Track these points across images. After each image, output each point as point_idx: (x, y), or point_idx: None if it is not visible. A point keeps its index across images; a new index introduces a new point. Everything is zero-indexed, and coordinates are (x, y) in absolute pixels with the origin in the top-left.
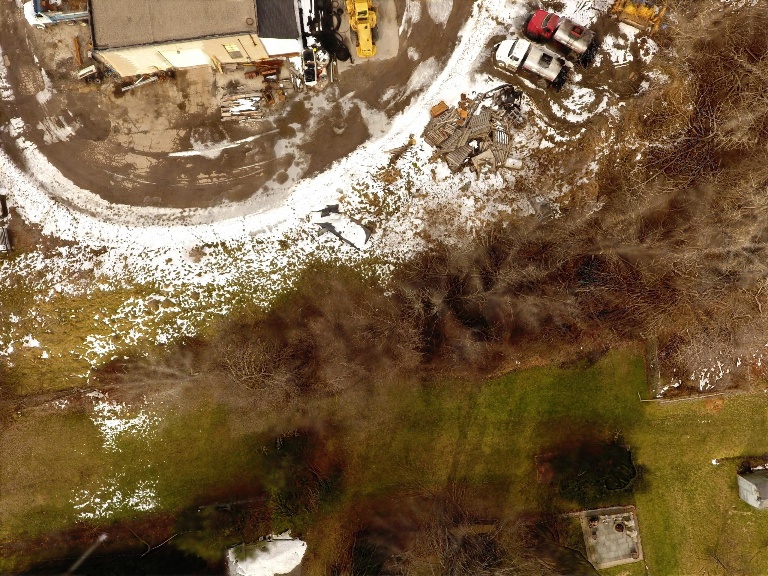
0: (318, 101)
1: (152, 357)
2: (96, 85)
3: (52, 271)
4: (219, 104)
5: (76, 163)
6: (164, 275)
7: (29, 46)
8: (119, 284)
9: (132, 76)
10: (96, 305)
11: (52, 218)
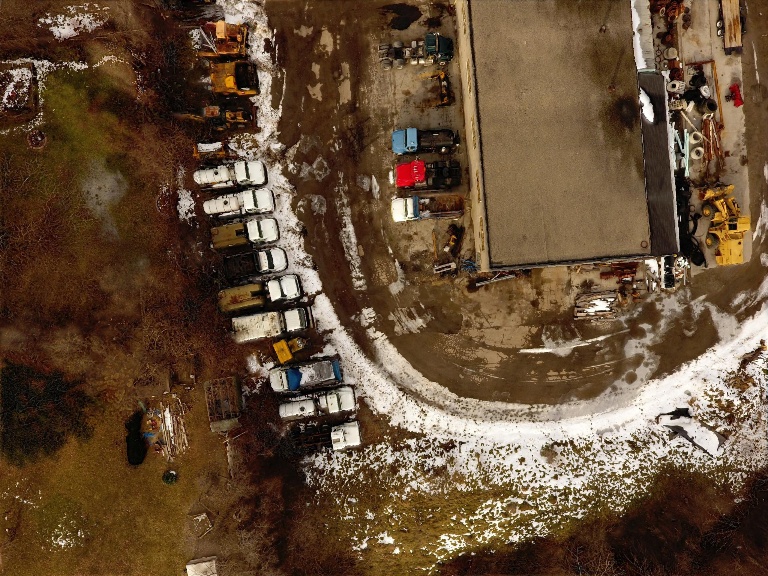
0: (670, 303)
1: (498, 553)
2: (450, 279)
3: (405, 466)
4: (572, 303)
5: (426, 355)
6: (520, 476)
7: (384, 237)
8: (476, 484)
9: (488, 272)
10: (454, 505)
11: (400, 409)
